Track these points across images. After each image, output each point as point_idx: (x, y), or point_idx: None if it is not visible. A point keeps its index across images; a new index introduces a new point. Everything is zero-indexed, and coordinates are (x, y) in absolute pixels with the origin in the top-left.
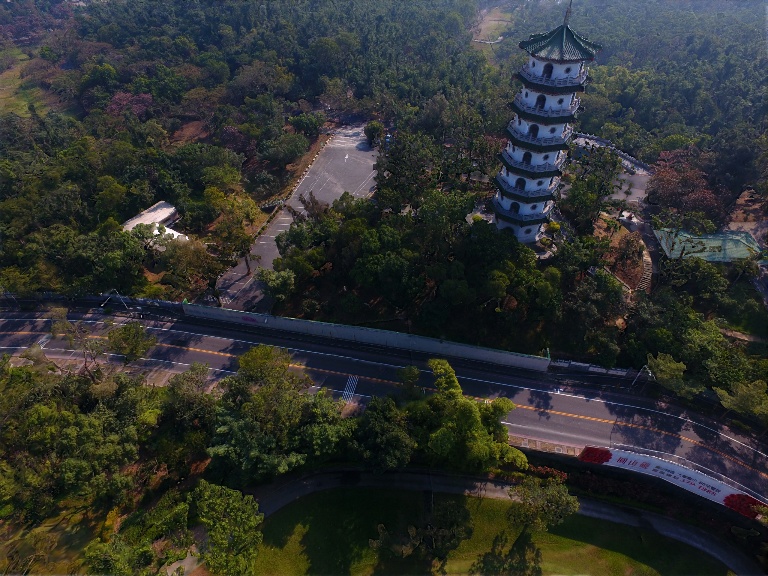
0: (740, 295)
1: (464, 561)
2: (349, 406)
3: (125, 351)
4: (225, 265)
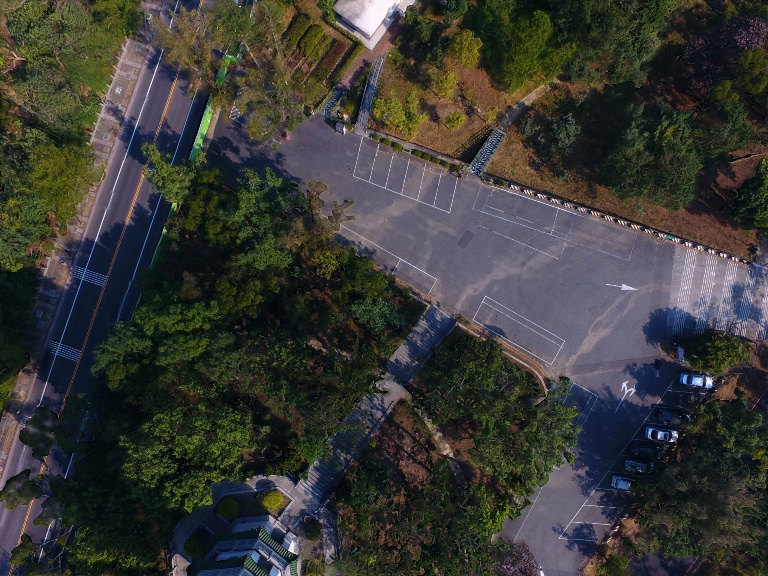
0: None
1: None
2: (65, 274)
3: (99, 5)
4: (321, 99)
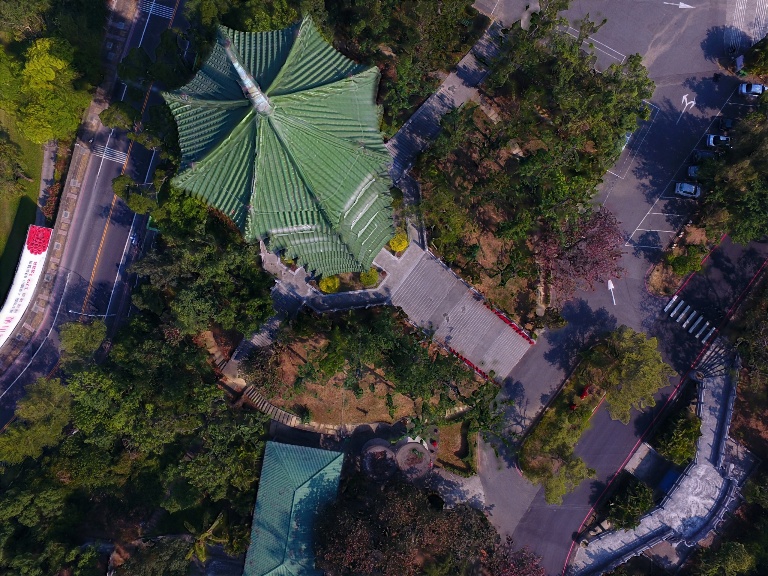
0: (179, 494)
1: (4, 115)
2: (134, 7)
3: None
4: None
